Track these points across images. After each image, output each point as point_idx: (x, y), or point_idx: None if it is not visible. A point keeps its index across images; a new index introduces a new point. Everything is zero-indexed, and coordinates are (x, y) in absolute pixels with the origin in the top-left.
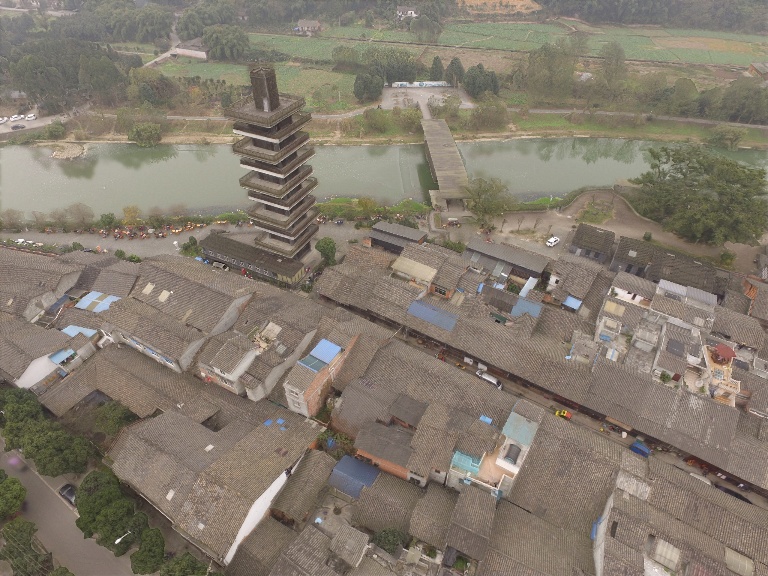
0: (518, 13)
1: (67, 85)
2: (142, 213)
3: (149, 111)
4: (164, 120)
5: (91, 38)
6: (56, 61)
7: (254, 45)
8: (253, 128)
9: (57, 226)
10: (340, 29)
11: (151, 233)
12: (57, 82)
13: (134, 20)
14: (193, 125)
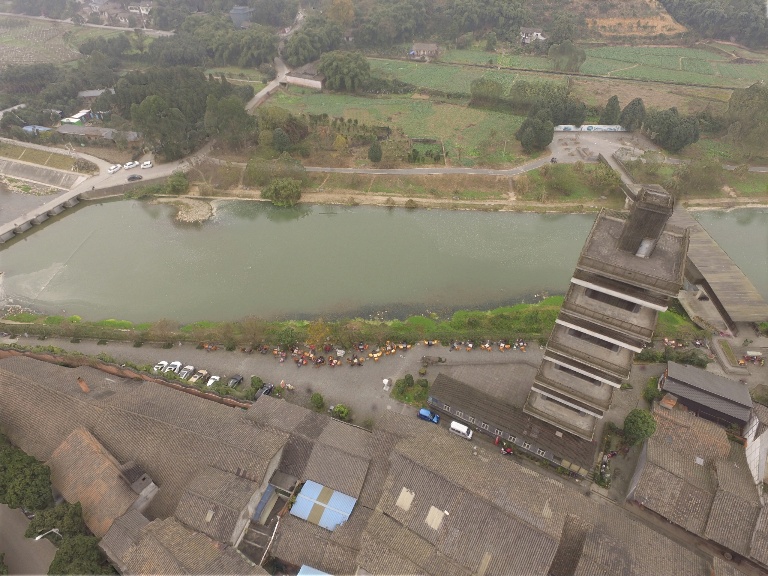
0: (661, 35)
1: (189, 128)
2: (307, 311)
3: (287, 163)
4: (305, 175)
5: (191, 62)
6: (170, 96)
7: (371, 73)
8: (615, 282)
9: (217, 339)
10: (458, 53)
11: (341, 357)
12: (180, 126)
13: (238, 43)
14: (334, 179)
